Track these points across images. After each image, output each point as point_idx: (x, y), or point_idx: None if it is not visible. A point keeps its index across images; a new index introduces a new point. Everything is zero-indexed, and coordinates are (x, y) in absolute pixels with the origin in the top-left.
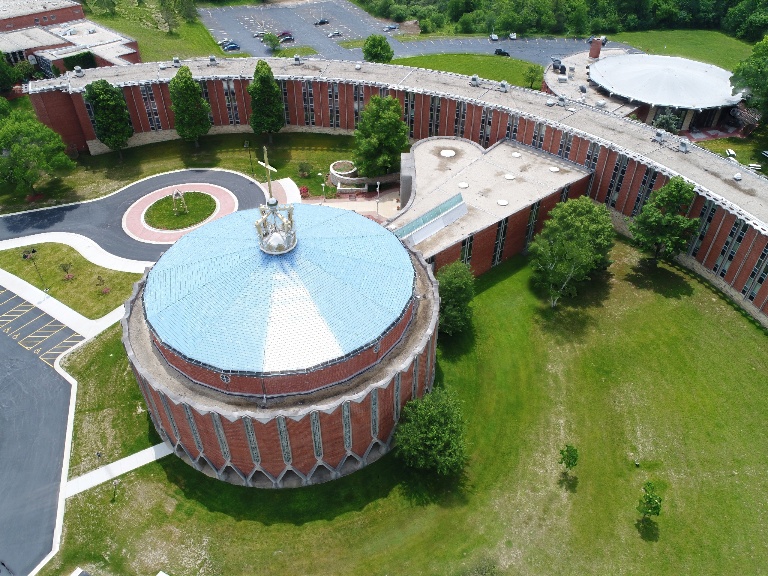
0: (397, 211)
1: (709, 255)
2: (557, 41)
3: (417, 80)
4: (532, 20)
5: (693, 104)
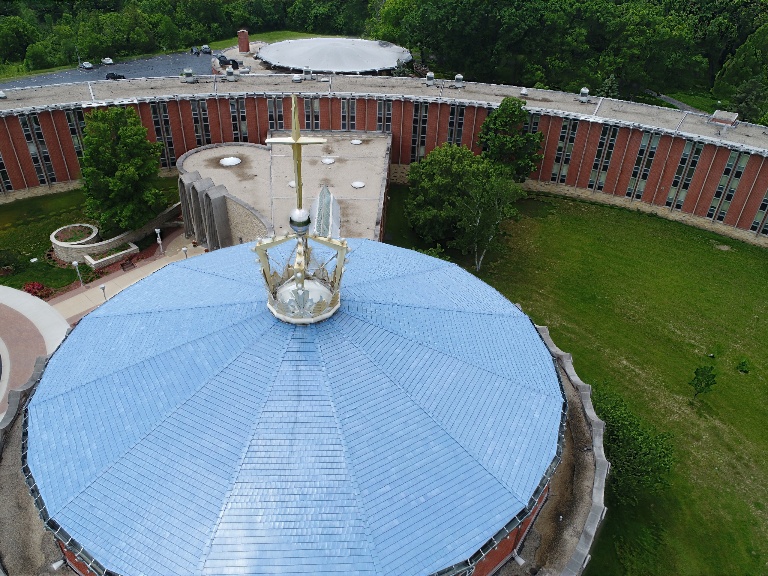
0: None
1: (543, 168)
2: (161, 58)
3: (111, 92)
4: (121, 40)
5: (381, 67)
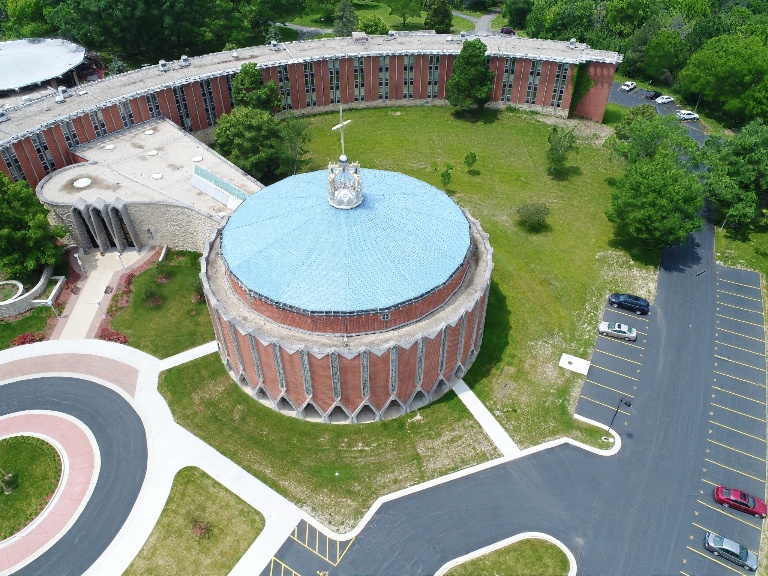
0: (123, 255)
1: None
2: None
3: None
4: None
5: (66, 64)
